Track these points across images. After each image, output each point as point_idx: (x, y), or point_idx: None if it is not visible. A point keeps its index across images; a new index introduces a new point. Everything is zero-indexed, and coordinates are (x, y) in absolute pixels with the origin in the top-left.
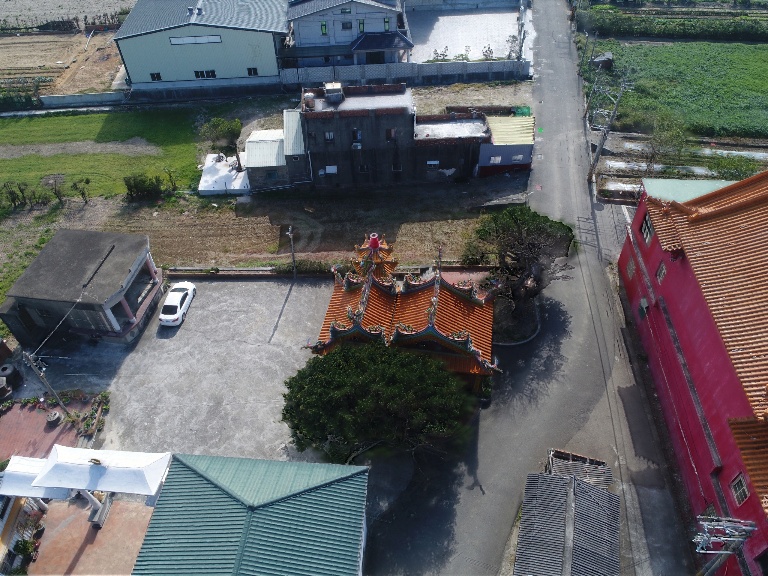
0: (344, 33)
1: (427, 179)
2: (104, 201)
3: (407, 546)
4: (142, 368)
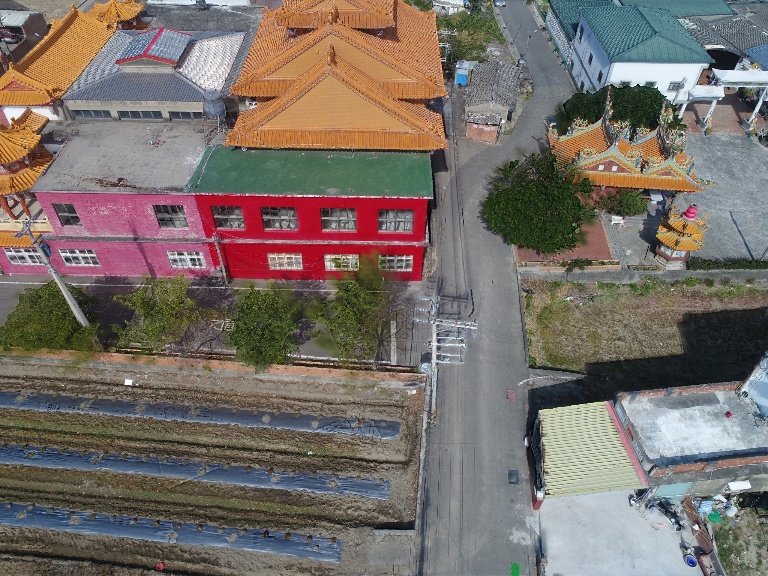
0: None
1: None
2: None
3: None
4: None
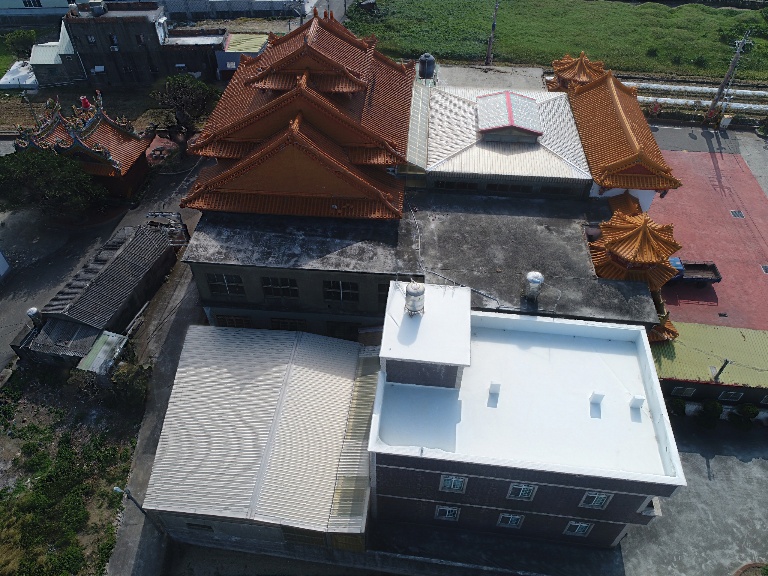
0: None
1: None
2: None
3: (36, 278)
4: None
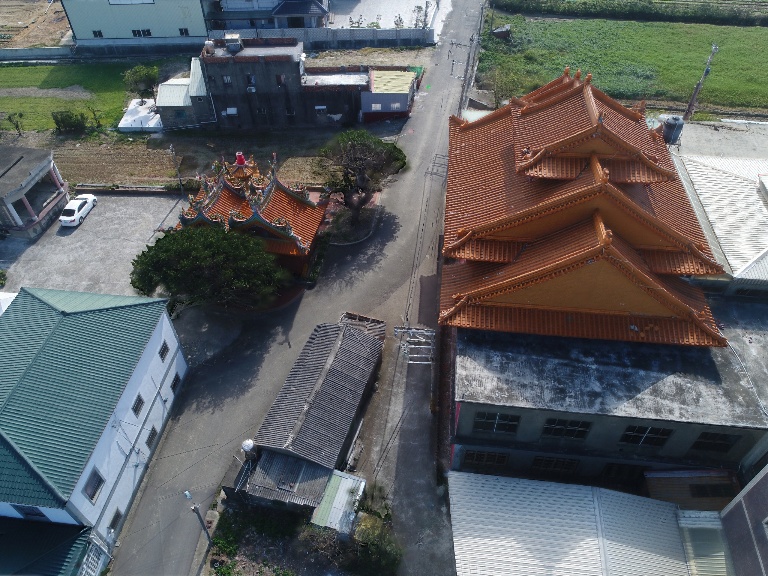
0: None
1: (318, 123)
2: (36, 134)
3: (219, 381)
4: (39, 256)
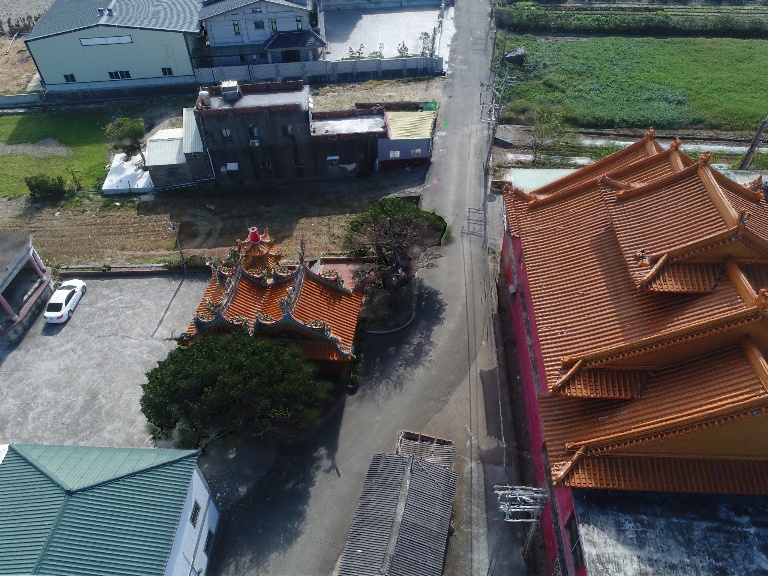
0: (257, 32)
1: (329, 174)
2: (7, 202)
3: (258, 528)
4: (23, 365)
